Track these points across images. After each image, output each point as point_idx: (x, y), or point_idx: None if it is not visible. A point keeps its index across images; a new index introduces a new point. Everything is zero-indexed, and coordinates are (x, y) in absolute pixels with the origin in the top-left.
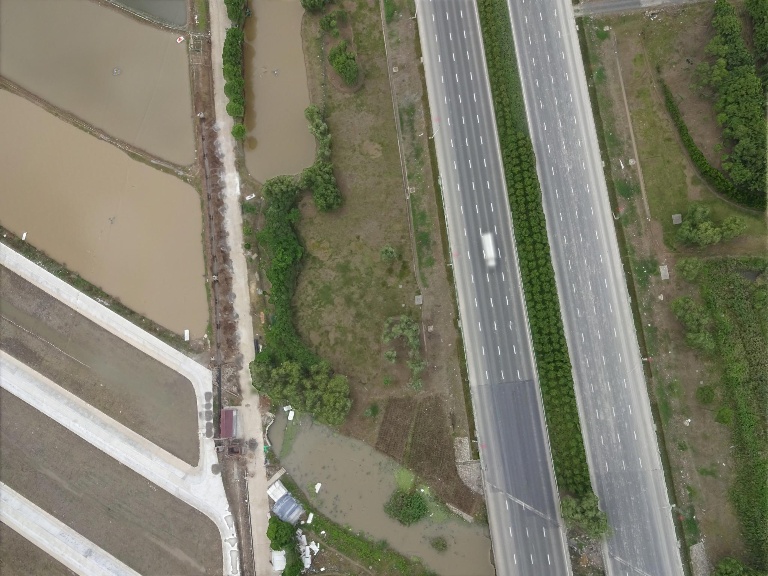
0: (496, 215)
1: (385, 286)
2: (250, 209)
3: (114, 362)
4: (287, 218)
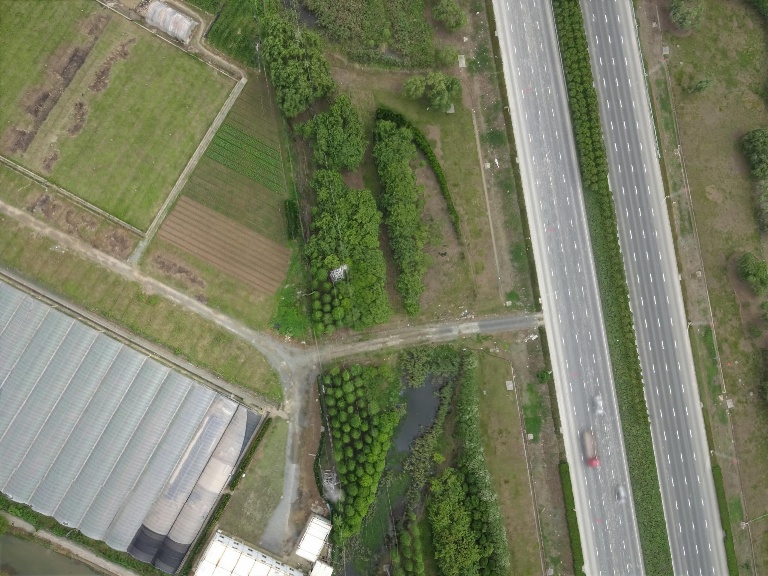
0: (608, 118)
1: (695, 64)
2: None
3: None
4: None
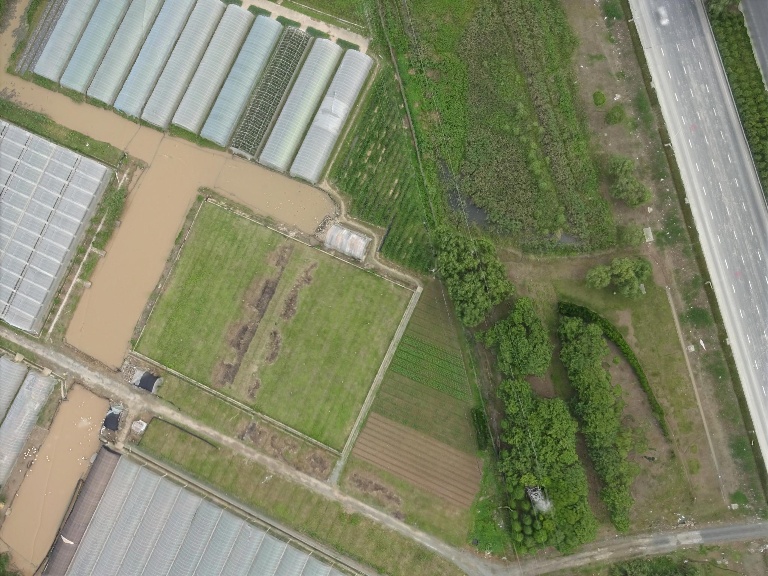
0: None
1: None
2: None
3: None
4: None
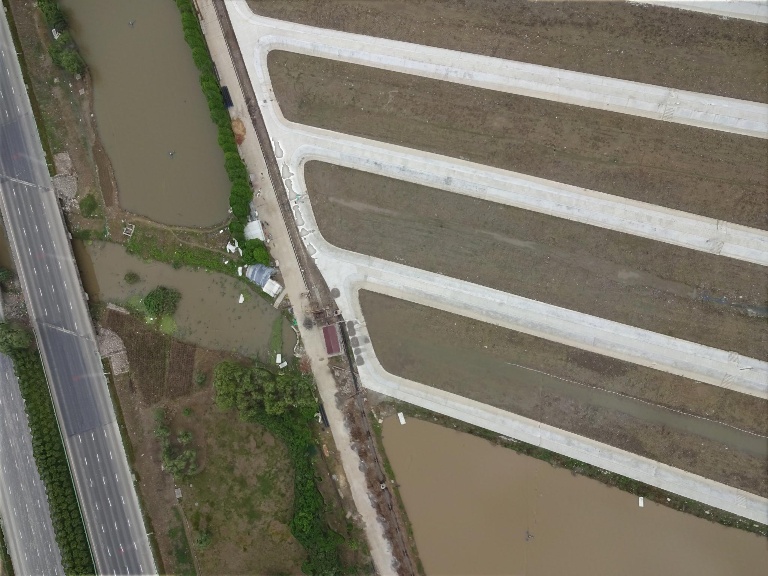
0: None
1: (211, 502)
2: (354, 571)
3: (479, 374)
4: (312, 565)
